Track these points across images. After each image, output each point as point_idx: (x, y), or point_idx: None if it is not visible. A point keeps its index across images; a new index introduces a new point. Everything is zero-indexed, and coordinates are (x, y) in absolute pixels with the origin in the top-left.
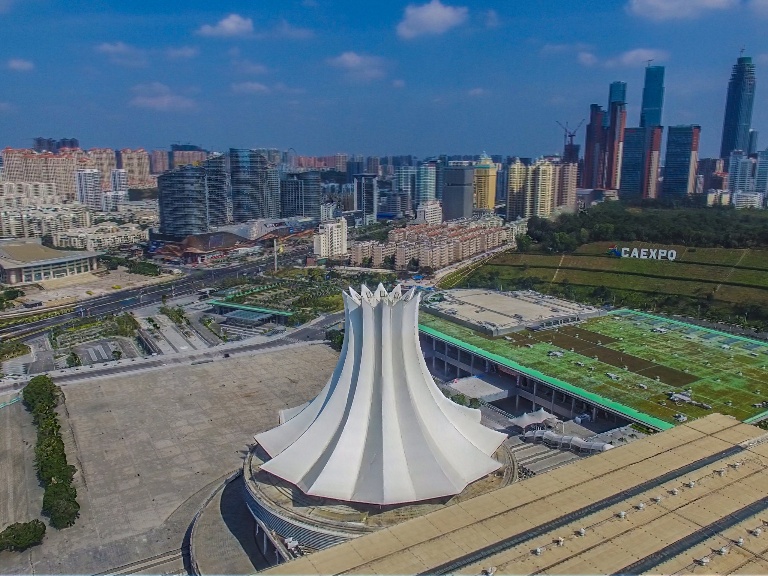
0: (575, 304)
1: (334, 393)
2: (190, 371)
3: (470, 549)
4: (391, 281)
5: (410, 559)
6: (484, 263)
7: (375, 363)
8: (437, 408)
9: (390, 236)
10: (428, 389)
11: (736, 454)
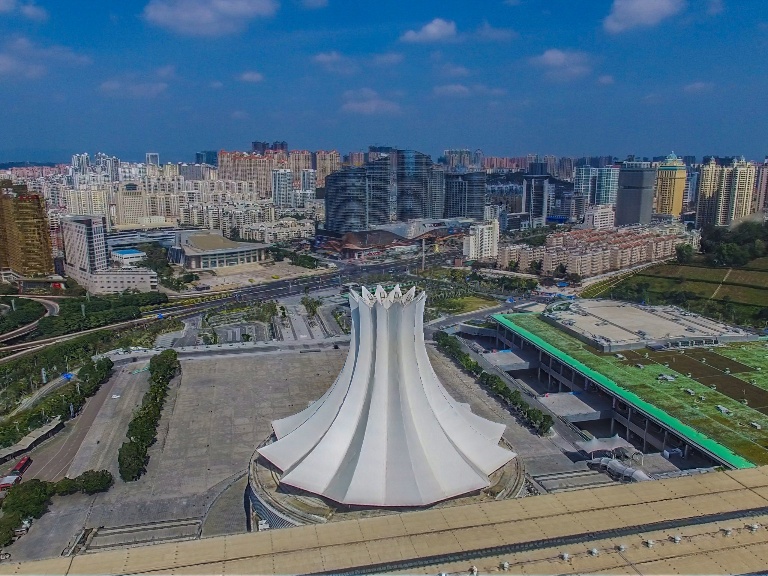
0: (721, 325)
1: (334, 389)
2: (296, 358)
3: (378, 560)
4: (531, 287)
5: (314, 558)
6: (635, 273)
7: (371, 363)
8: (432, 416)
9: (548, 240)
10: (425, 395)
11: (766, 515)
